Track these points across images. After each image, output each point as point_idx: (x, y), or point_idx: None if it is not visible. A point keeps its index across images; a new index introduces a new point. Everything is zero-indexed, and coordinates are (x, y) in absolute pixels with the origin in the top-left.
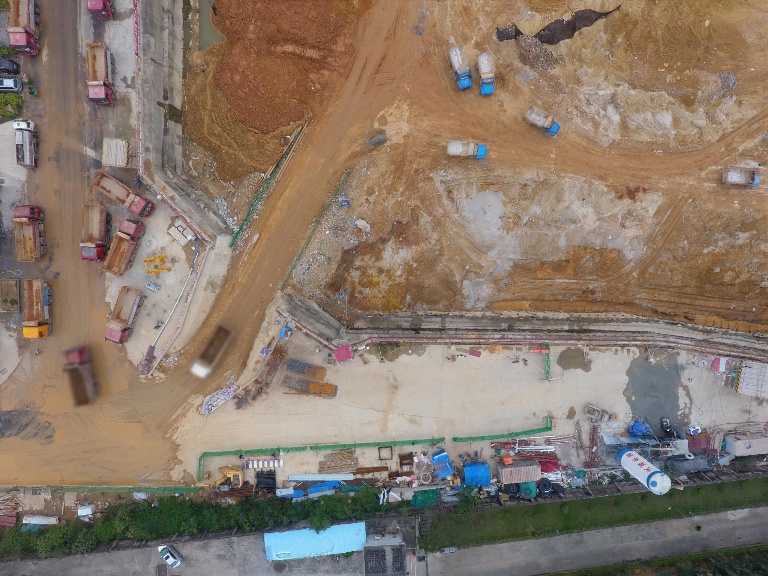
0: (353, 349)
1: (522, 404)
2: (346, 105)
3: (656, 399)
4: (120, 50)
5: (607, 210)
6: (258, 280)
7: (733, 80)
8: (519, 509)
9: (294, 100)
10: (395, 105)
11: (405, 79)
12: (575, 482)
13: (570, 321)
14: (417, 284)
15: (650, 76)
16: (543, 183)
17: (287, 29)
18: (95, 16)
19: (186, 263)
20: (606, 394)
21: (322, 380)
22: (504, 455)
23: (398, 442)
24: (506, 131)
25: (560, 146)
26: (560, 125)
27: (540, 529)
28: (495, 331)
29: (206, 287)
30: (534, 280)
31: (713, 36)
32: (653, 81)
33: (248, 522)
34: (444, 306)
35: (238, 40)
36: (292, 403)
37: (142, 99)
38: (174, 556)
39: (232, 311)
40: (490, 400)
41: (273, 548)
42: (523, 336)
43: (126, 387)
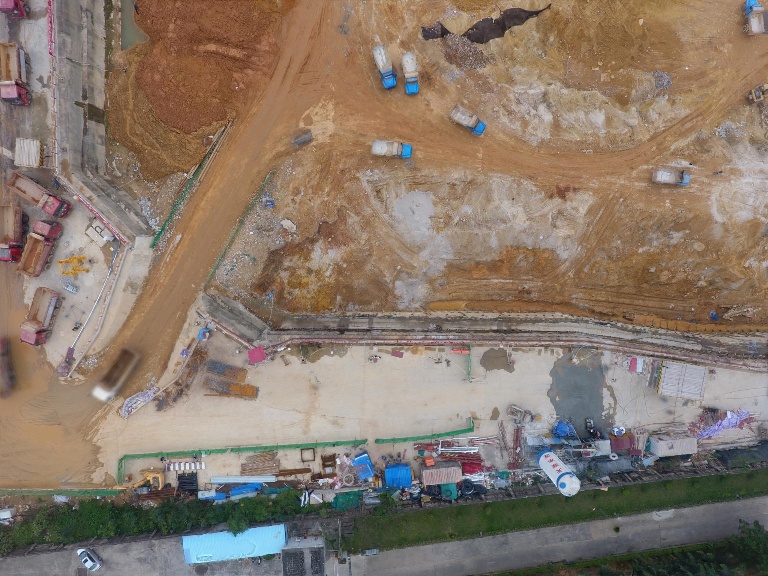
0: (273, 350)
1: (445, 405)
2: (270, 105)
3: (580, 400)
4: (36, 49)
5: (537, 210)
6: (180, 281)
7: (667, 79)
8: (442, 511)
9: (216, 100)
10: (320, 104)
11: (330, 78)
12: (498, 483)
13: (499, 321)
14: (346, 284)
15: (584, 75)
16: (471, 183)
17: (209, 28)
18: (8, 15)
19: (105, 264)
20: (530, 395)
21: (243, 381)
22: (427, 456)
23: (320, 444)
24: (433, 130)
25: (487, 145)
26: (487, 124)
27: (464, 531)
28: (422, 332)
29: (125, 288)
30: (470, 280)
31: (647, 35)
32: (587, 80)
33: (166, 525)
34: (376, 307)
35: (160, 39)
36: (213, 405)
37: (58, 99)
38: (93, 559)
39: (154, 312)
40: (413, 401)
41: (192, 551)
42: (446, 337)
43: (46, 389)
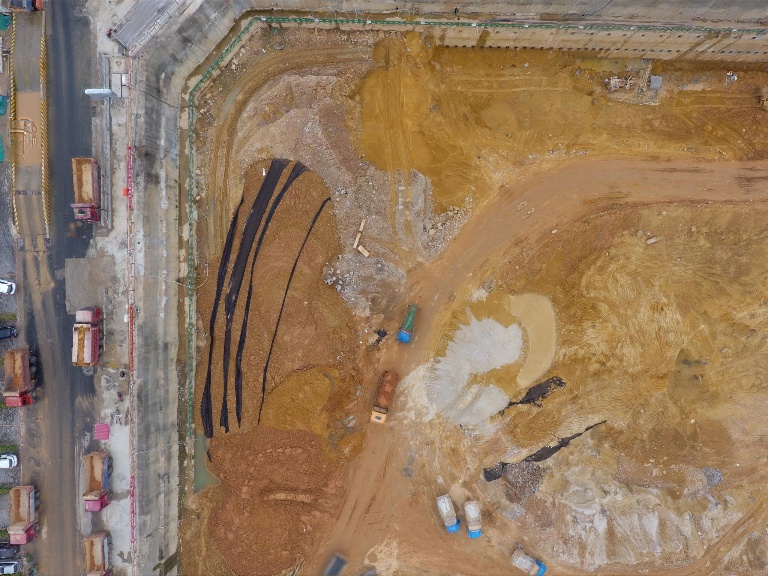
0: None
1: None
2: (337, 545)
3: None
4: (117, 527)
5: None
6: None
7: (718, 477)
8: None
9: (286, 552)
10: (385, 543)
11: (394, 518)
12: None
13: None
14: None
15: (637, 470)
16: None
17: (279, 482)
18: None
19: None
20: None
21: None
22: None
23: None
24: (493, 566)
25: None
26: (546, 560)
27: None
28: None
29: None
30: None
31: (698, 434)
32: (640, 474)
33: None
34: None
35: (232, 491)
36: None
37: (138, 575)
38: None
39: None
40: None
41: None
42: None
43: None
